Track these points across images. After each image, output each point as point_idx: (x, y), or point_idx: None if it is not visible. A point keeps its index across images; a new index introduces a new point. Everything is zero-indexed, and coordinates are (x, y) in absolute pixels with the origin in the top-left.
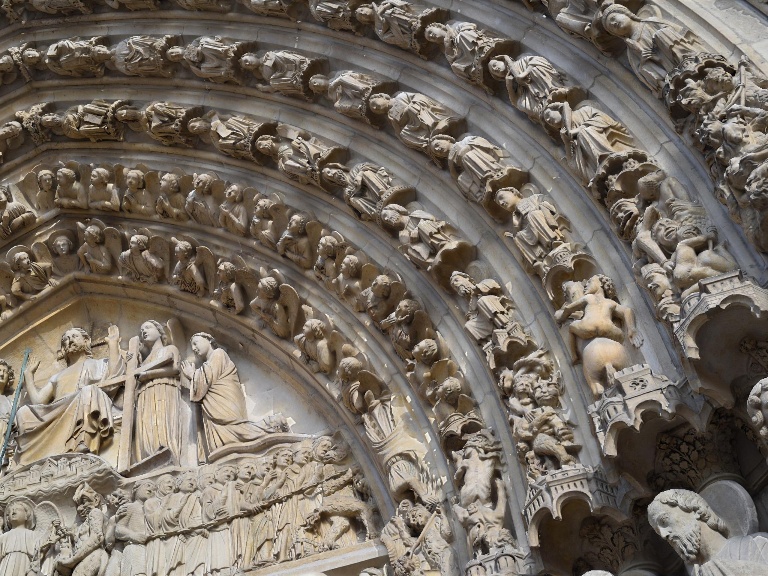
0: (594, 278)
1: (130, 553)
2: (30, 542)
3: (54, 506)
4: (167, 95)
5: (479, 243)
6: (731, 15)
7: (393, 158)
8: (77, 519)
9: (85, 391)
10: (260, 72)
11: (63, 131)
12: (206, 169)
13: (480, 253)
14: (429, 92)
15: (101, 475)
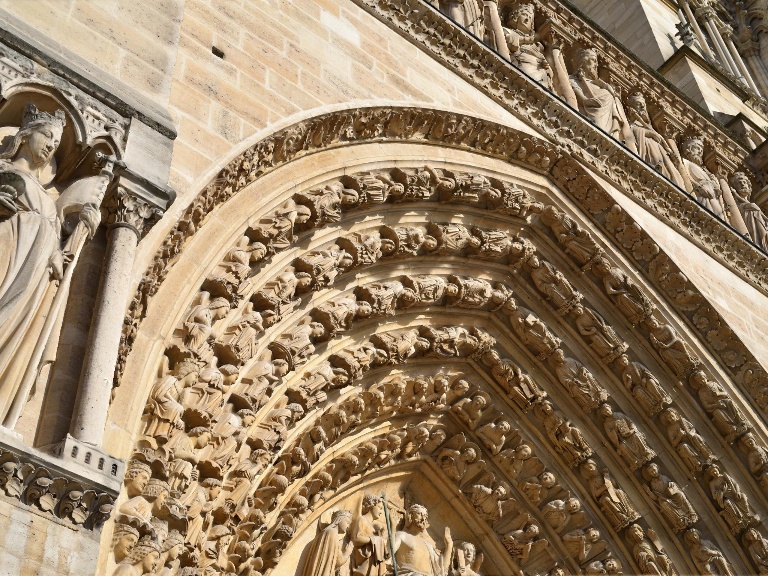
0: None
1: None
2: None
3: None
4: (575, 419)
5: None
6: None
7: None
8: None
9: None
10: (653, 480)
11: (493, 368)
12: (573, 491)
13: None
14: None
15: None
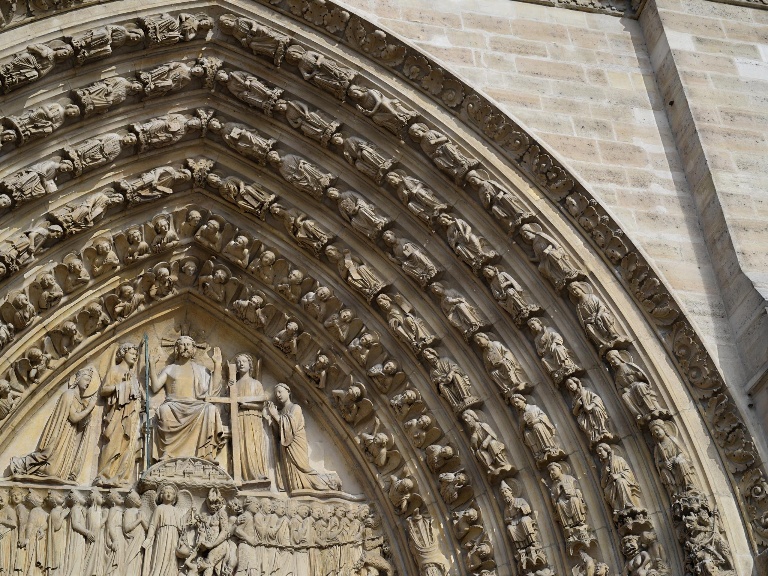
0: (603, 566)
1: (247, 551)
2: (178, 519)
3: (191, 495)
4: (311, 210)
5: (521, 470)
6: (714, 466)
7: (474, 371)
8: (203, 507)
9: (212, 410)
10: (393, 246)
11: (219, 189)
12: (325, 279)
13: (520, 477)
14: (514, 350)
15: (229, 487)
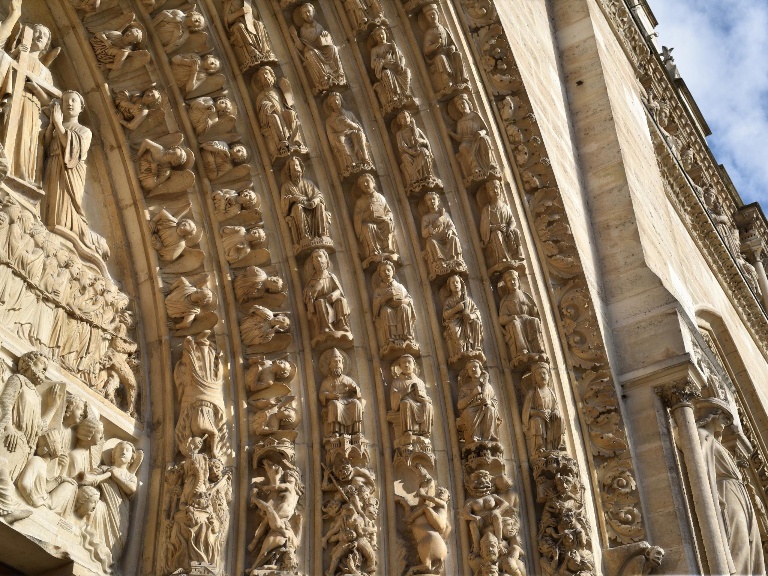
0: None
1: None
2: None
3: None
4: None
5: (357, 347)
6: None
7: None
8: None
9: (6, 60)
10: (304, 24)
11: None
12: (200, 8)
13: (354, 354)
14: (393, 215)
15: None
